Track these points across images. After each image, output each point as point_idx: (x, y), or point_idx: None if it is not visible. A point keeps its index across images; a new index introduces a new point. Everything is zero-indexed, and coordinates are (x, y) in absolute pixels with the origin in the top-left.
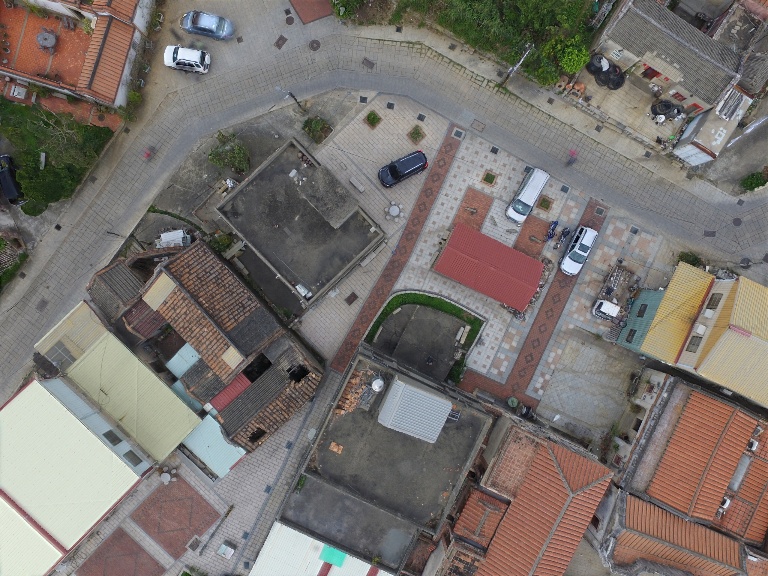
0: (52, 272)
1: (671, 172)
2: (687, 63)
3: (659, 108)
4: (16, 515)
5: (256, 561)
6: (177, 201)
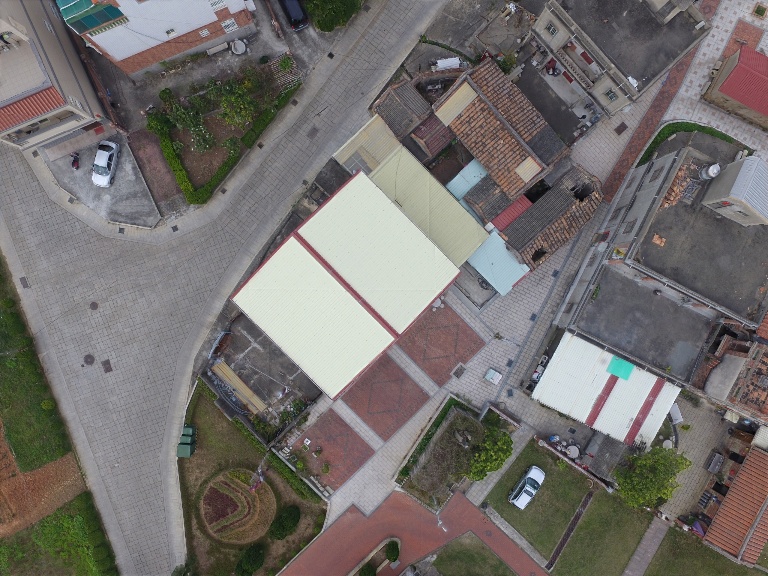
0: (324, 100)
1: None
2: None
3: None
4: (350, 298)
5: (544, 373)
6: (448, 32)
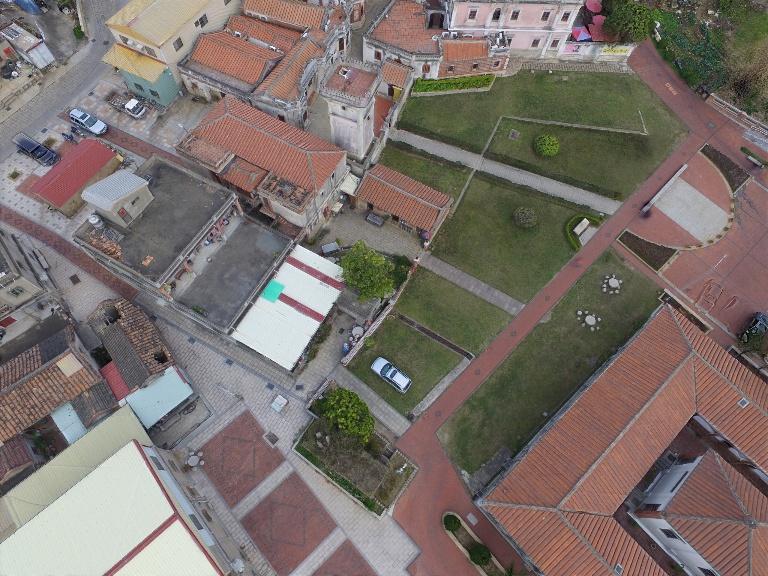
0: None
1: (58, 73)
2: None
3: (5, 73)
4: (121, 573)
5: None
6: None
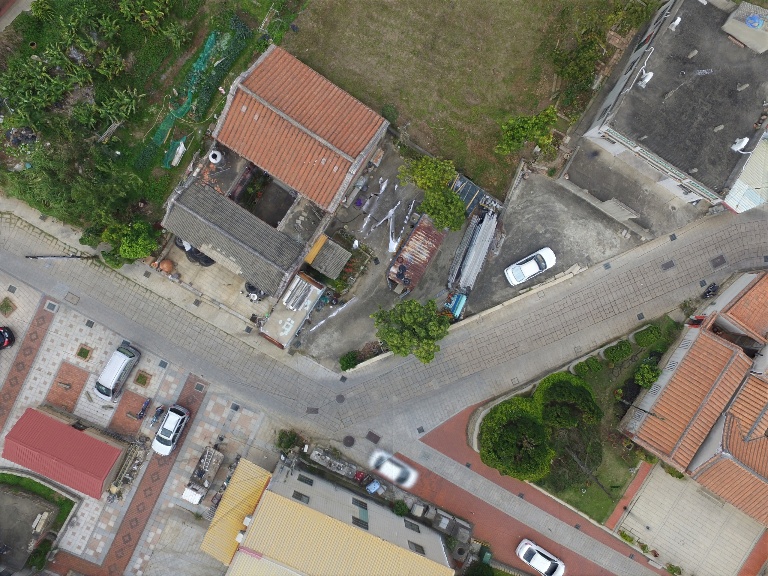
0: None
1: (273, 348)
2: (242, 257)
3: (247, 288)
4: None
5: None
6: None
